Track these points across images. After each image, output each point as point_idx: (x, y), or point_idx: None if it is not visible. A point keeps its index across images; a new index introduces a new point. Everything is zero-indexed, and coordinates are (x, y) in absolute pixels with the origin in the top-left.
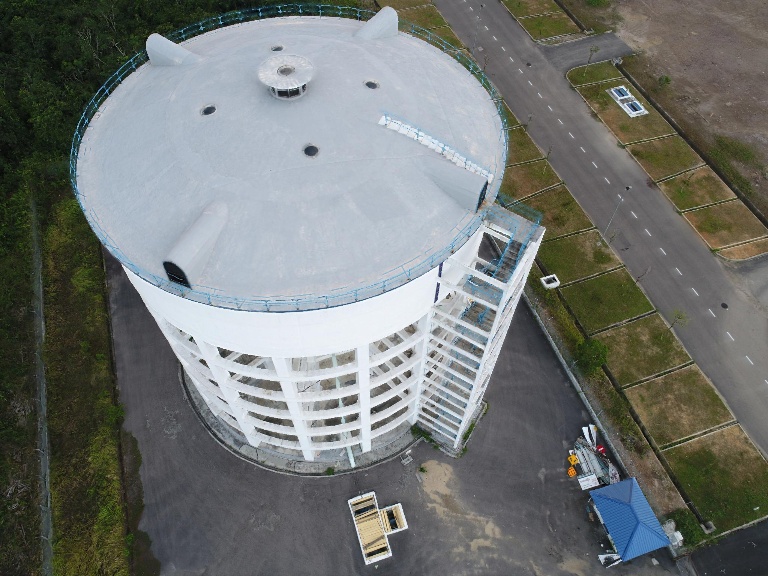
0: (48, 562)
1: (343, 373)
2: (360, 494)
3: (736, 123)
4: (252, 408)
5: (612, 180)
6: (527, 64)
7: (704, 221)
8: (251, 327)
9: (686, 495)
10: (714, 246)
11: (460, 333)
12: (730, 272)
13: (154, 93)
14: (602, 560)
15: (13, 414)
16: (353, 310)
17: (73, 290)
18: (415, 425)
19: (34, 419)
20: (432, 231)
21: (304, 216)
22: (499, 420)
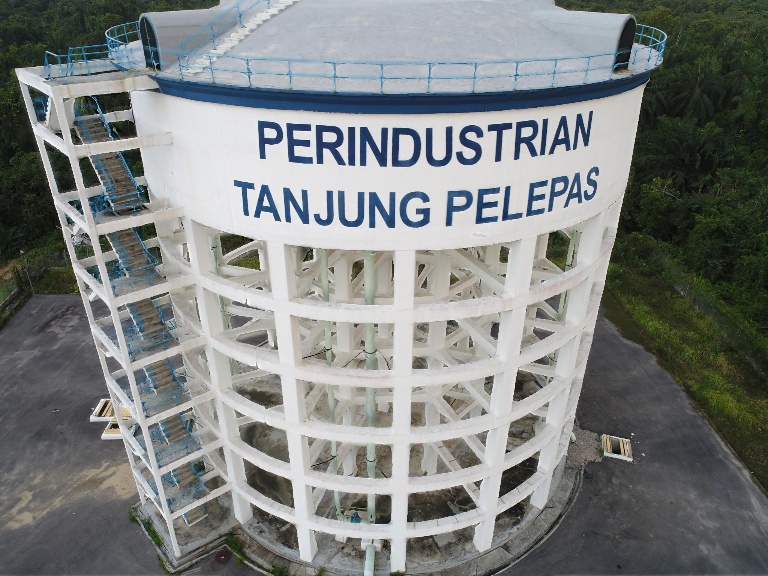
0: None
1: None
2: None
3: None
4: (243, 246)
5: None
6: None
7: None
8: None
9: None
10: None
11: None
12: None
13: None
14: None
15: None
16: None
17: None
18: None
19: None
20: None
21: None
22: None
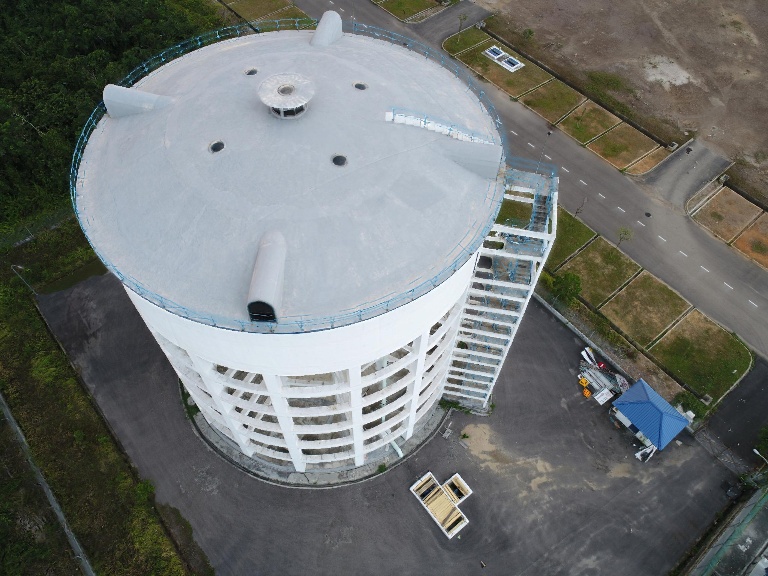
0: None
1: (406, 364)
2: (418, 479)
3: (597, 58)
4: (312, 430)
5: (518, 132)
6: (404, 44)
7: (605, 148)
8: (334, 343)
9: (679, 380)
10: (621, 167)
11: (499, 294)
12: (641, 185)
13: (141, 144)
14: (639, 457)
15: (26, 533)
16: (425, 298)
17: (37, 383)
18: (441, 399)
19: (53, 529)
20: (470, 206)
21: (359, 223)
22: (510, 370)
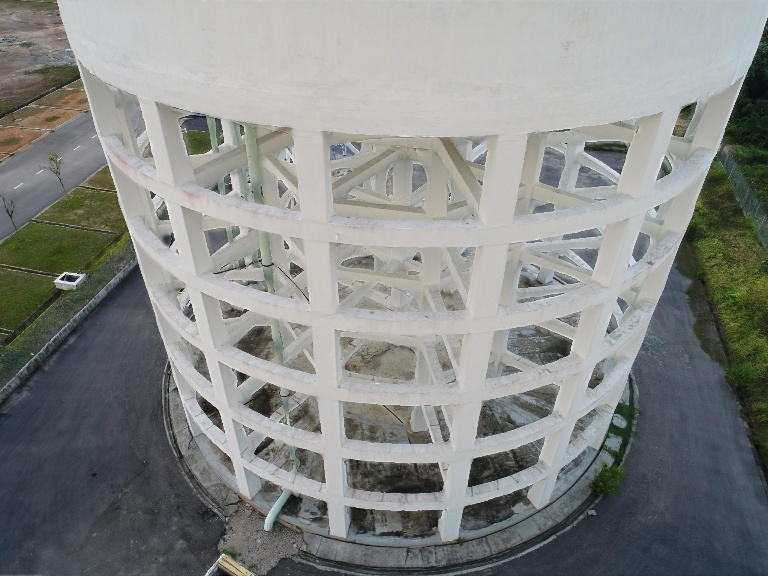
0: None
1: None
2: None
3: None
4: None
5: None
6: None
7: None
8: None
9: None
10: None
11: None
12: None
13: None
14: None
15: None
16: None
17: None
18: None
19: None
20: None
21: None
22: None
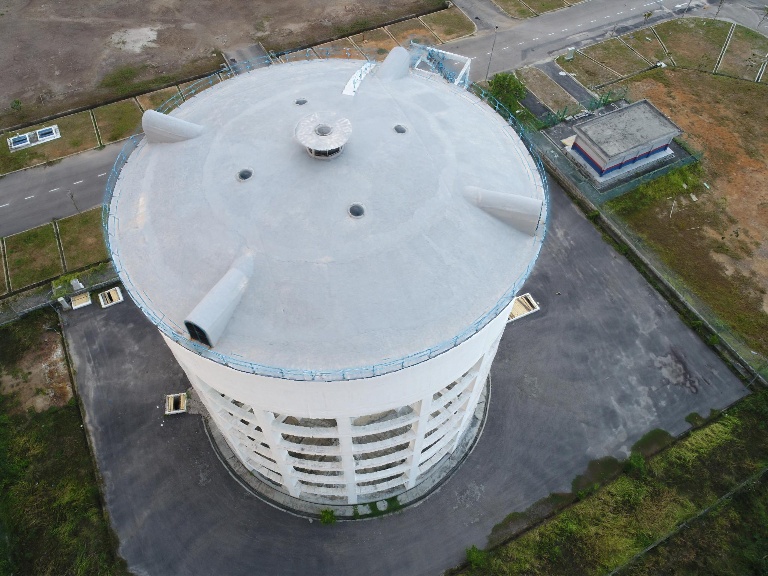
0: (626, 568)
1: None
2: None
3: (85, 73)
4: None
5: None
6: None
7: None
8: None
9: None
10: None
11: None
12: None
13: (309, 291)
14: None
15: None
16: None
17: None
18: None
19: None
20: (437, 88)
21: (461, 139)
22: None
